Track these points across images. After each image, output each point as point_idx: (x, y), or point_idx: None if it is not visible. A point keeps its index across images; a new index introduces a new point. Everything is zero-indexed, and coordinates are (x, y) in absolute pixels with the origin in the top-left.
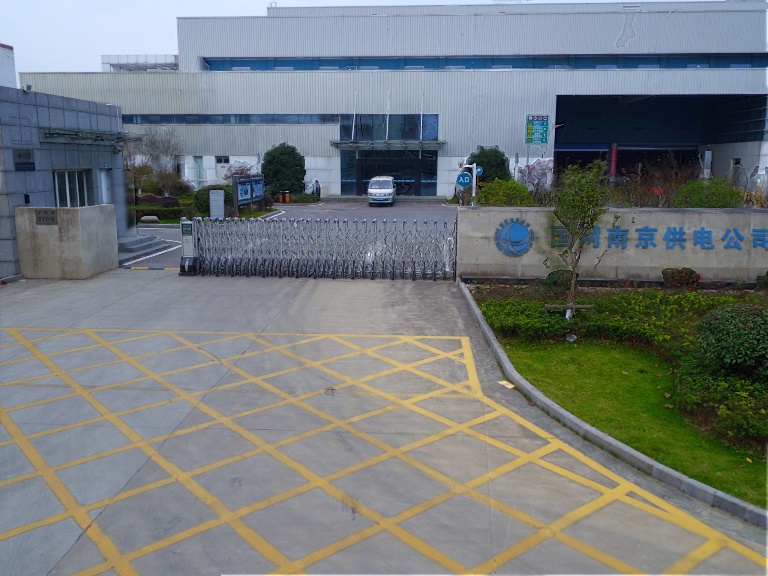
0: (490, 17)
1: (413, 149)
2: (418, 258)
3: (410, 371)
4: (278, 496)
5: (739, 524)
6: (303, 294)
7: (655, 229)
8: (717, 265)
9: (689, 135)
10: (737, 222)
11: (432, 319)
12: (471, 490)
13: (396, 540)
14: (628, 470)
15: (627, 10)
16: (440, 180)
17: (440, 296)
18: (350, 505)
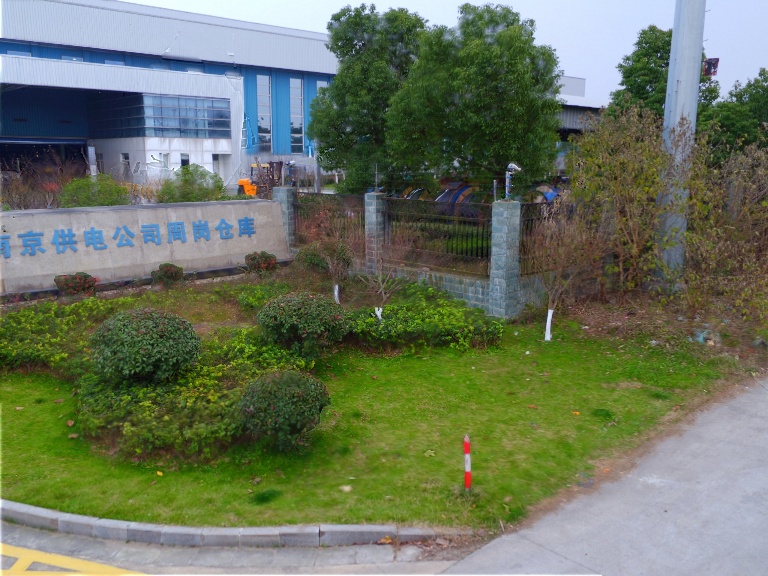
0: None
1: None
2: None
3: None
4: None
5: (156, 552)
6: None
7: (41, 233)
8: (113, 265)
9: (75, 129)
10: (125, 219)
11: None
12: None
13: None
14: (29, 534)
15: None
16: None
17: None
18: None
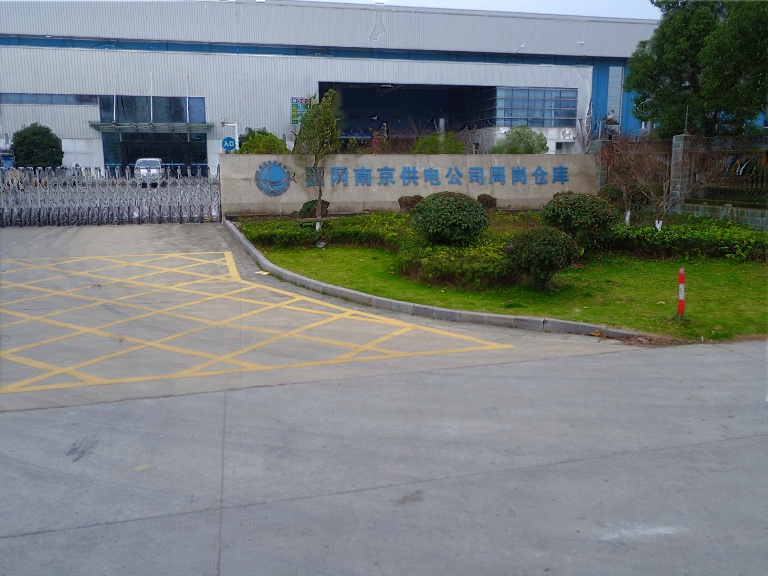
0: (251, 6)
1: (181, 132)
2: (184, 203)
3: (175, 271)
4: (48, 340)
5: (429, 320)
6: (66, 235)
7: (393, 169)
8: None
9: None
10: (457, 162)
11: (198, 243)
12: (226, 323)
13: (159, 350)
14: (355, 305)
15: (377, 6)
16: (211, 163)
17: (206, 231)
18: (118, 338)
